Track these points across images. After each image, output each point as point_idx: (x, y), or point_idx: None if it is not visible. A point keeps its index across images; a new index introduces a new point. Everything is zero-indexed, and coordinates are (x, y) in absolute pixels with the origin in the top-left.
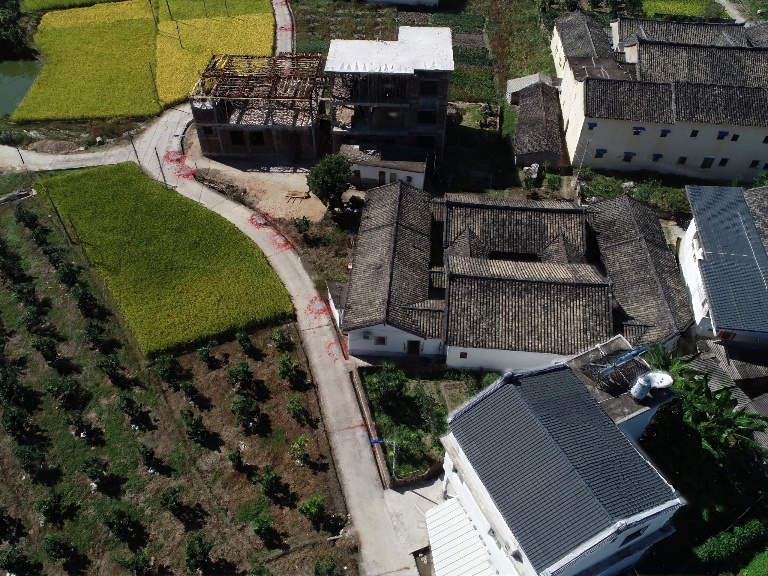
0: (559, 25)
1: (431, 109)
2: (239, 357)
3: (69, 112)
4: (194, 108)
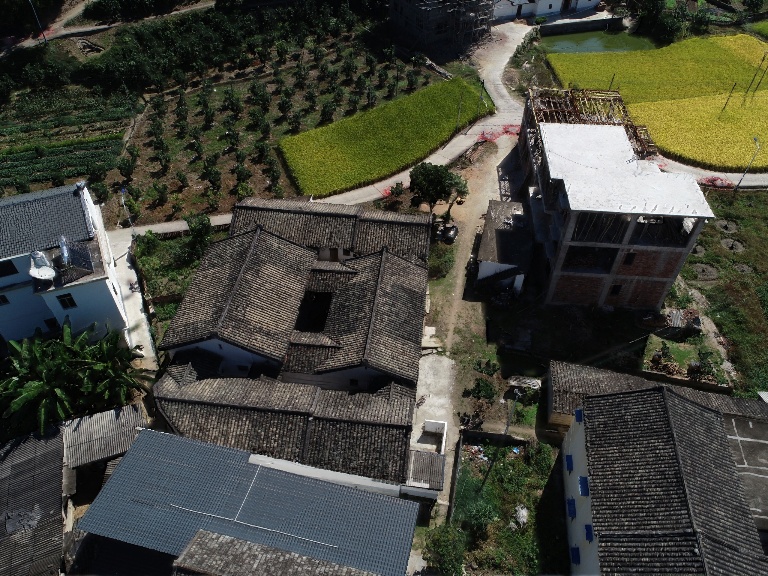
0: None
1: (553, 234)
2: (270, 181)
3: (564, 74)
4: (528, 100)
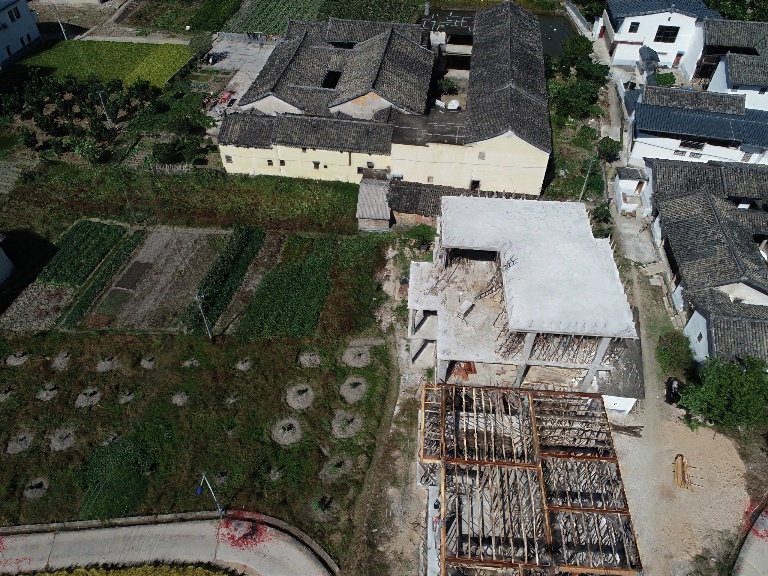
0: (244, 142)
1: None
2: None
3: None
4: None
